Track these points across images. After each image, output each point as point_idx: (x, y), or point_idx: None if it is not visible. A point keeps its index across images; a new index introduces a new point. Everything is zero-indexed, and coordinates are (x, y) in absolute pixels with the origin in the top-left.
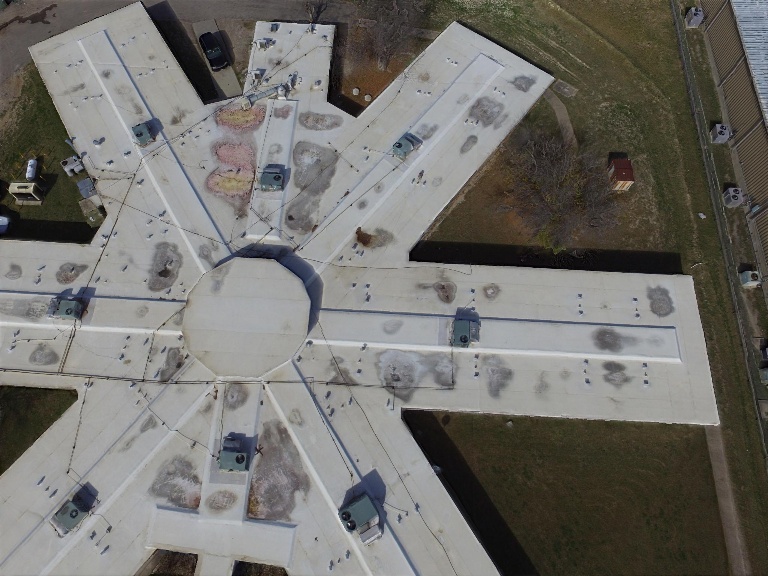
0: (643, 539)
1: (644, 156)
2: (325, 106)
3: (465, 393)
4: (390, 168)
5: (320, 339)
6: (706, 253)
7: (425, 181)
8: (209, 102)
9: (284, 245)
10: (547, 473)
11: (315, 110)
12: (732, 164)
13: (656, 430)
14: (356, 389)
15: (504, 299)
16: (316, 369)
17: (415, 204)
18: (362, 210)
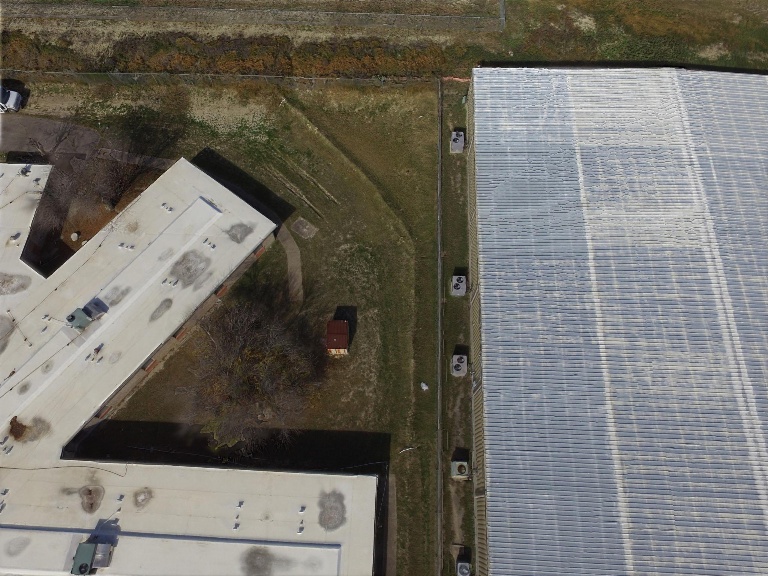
0: None
1: (375, 311)
2: (16, 265)
3: None
4: (65, 342)
5: None
6: (420, 434)
7: (101, 357)
8: None
9: None
10: None
11: (4, 270)
12: (469, 321)
13: None
14: None
15: (154, 508)
16: None
17: (84, 386)
18: (22, 396)
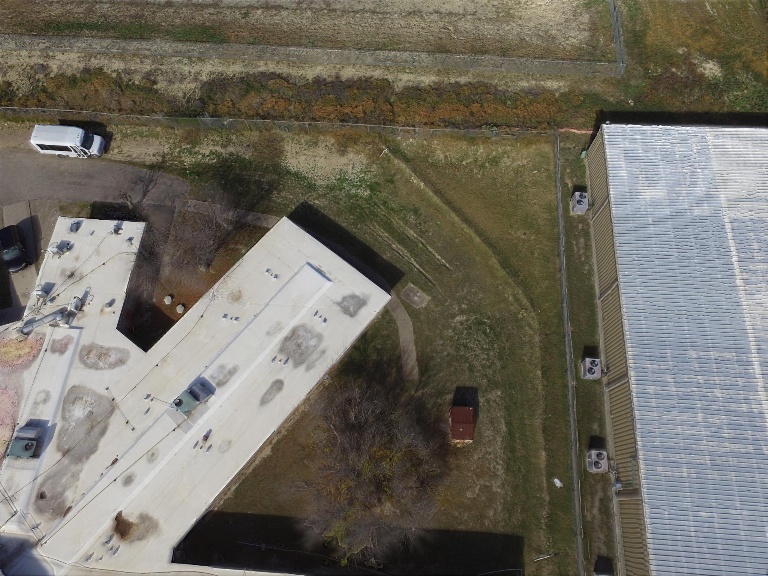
0: None
1: (498, 393)
2: (113, 335)
3: None
4: (170, 427)
5: None
6: (557, 539)
7: (210, 445)
8: (1, 312)
9: (27, 535)
10: None
11: (100, 341)
12: (604, 409)
13: None
14: None
15: None
16: None
17: (193, 478)
18: (127, 487)
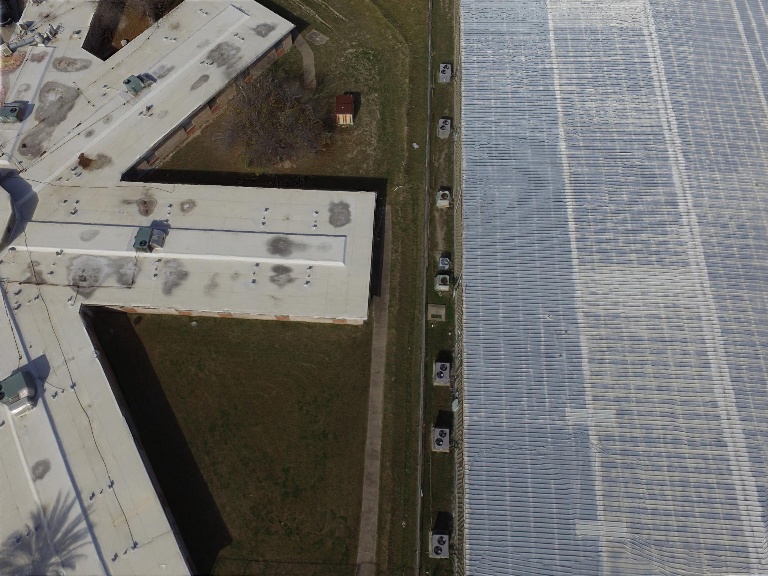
0: (293, 423)
1: (376, 95)
2: (79, 52)
3: (140, 291)
4: (122, 103)
5: (22, 246)
6: (411, 178)
7: (152, 114)
8: None
9: (12, 168)
10: (218, 366)
11: (69, 55)
12: (453, 100)
13: (327, 330)
14: (44, 288)
15: (197, 213)
16: (13, 271)
17: (138, 133)
18: (87, 138)
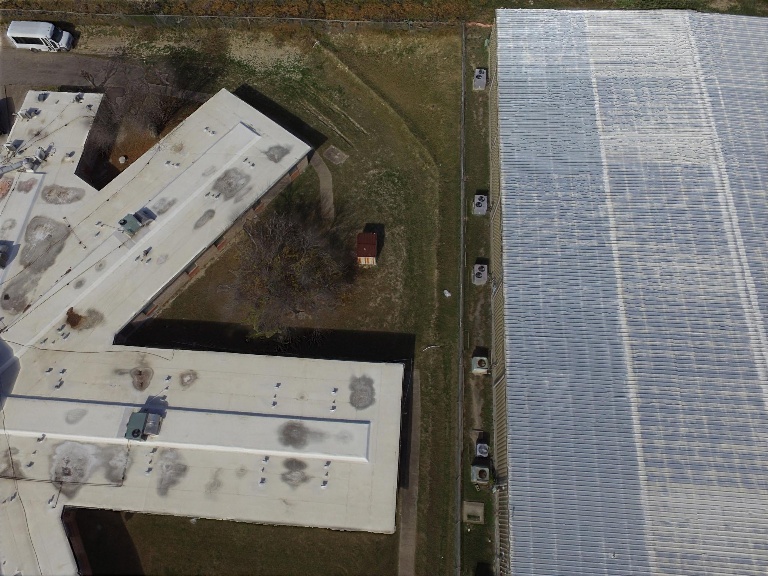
0: None
1: (401, 227)
2: (71, 179)
3: (132, 491)
4: (116, 245)
5: None
6: (443, 335)
7: (150, 258)
8: None
9: None
10: None
11: (60, 183)
12: (490, 237)
13: (346, 532)
14: (23, 484)
15: (199, 387)
16: None
17: (134, 283)
18: (77, 290)
